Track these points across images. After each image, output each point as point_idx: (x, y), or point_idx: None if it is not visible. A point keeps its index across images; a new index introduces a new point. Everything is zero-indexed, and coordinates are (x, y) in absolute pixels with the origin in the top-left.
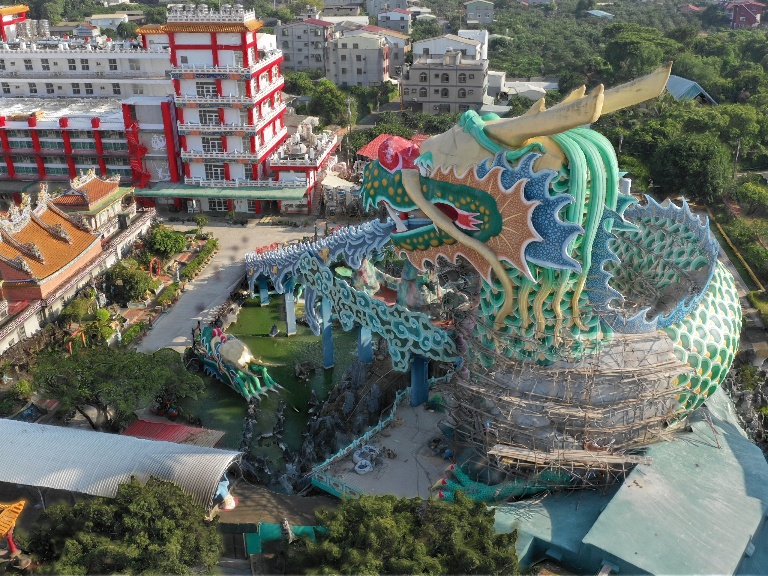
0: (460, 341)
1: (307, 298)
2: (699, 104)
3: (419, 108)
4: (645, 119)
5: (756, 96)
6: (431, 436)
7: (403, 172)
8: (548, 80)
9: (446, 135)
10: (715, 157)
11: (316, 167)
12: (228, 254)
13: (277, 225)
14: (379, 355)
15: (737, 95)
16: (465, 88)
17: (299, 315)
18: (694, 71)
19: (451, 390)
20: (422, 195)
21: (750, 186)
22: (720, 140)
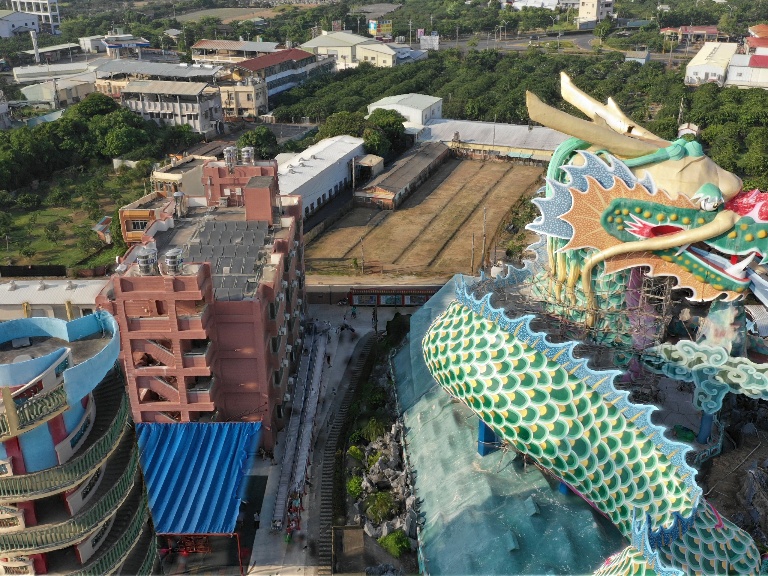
0: None
1: None
2: None
3: None
4: None
5: None
6: (665, 408)
7: None
8: None
9: None
10: None
11: None
12: None
13: None
14: None
15: None
16: None
17: None
18: None
19: None
20: None
21: None
22: None
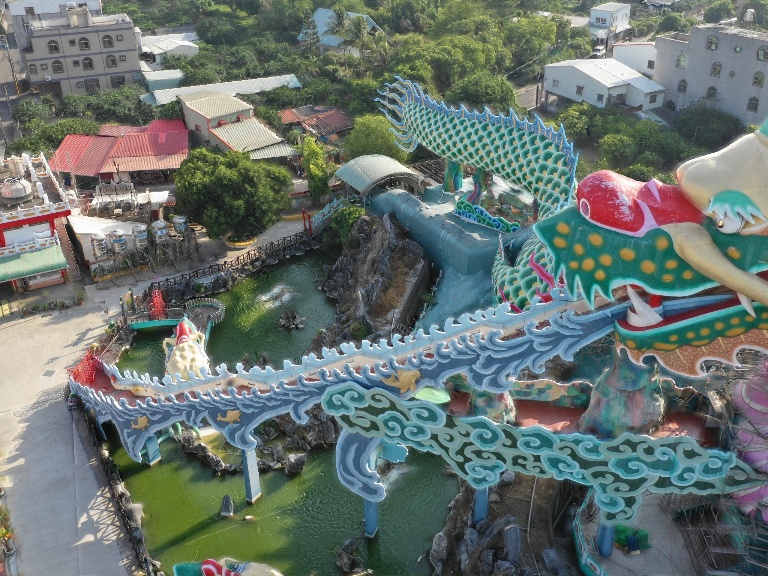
0: (750, 458)
1: (347, 451)
2: (425, 40)
3: (50, 88)
4: (376, 64)
5: (454, 24)
6: None
7: (671, 232)
8: (177, 31)
9: (766, 159)
10: (511, 98)
11: (68, 211)
12: (4, 393)
13: (31, 314)
14: (490, 495)
15: (398, 24)
16: (114, 54)
17: (227, 458)
18: (344, 3)
19: (746, 531)
20: (733, 265)
21: (544, 123)
22: (459, 76)
